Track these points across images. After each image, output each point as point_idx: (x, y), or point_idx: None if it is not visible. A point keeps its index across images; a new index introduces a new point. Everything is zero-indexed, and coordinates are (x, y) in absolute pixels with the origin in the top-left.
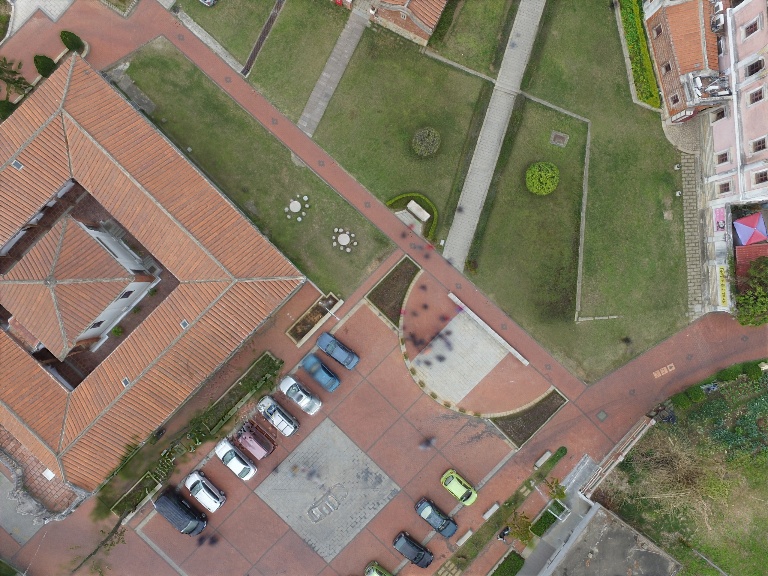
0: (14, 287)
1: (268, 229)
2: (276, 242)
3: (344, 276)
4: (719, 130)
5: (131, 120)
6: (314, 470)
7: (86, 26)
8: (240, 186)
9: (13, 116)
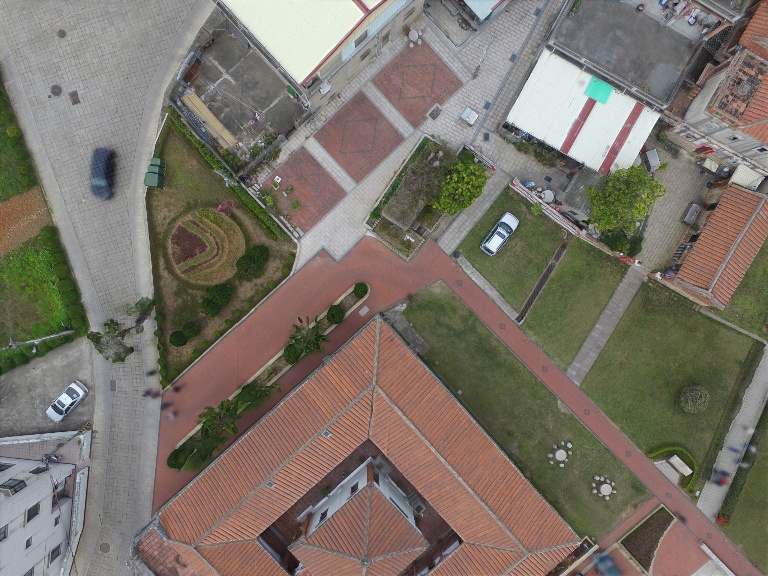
0: (319, 552)
1: (529, 472)
2: (537, 485)
3: (599, 520)
4: None
5: (430, 387)
6: None
7: (367, 267)
8: (505, 429)
9: (317, 378)
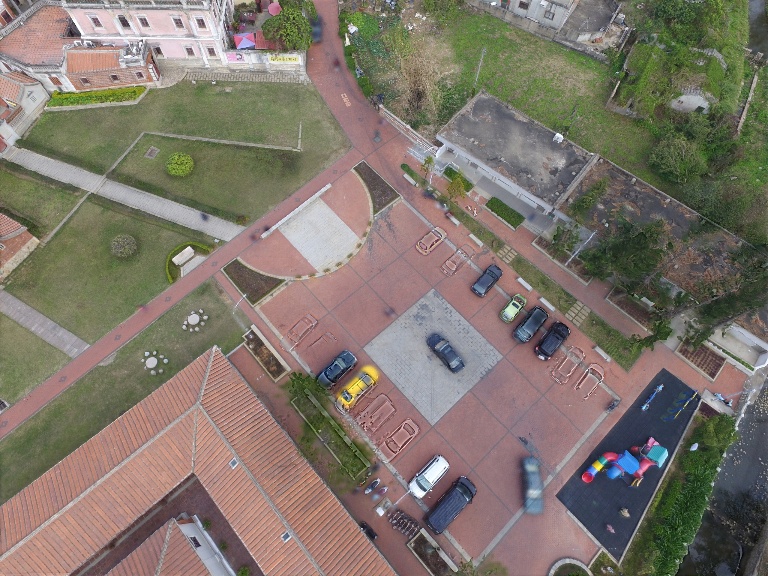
0: None
1: None
2: None
3: (230, 324)
4: (170, 53)
5: None
6: (413, 364)
7: None
8: None
9: None
